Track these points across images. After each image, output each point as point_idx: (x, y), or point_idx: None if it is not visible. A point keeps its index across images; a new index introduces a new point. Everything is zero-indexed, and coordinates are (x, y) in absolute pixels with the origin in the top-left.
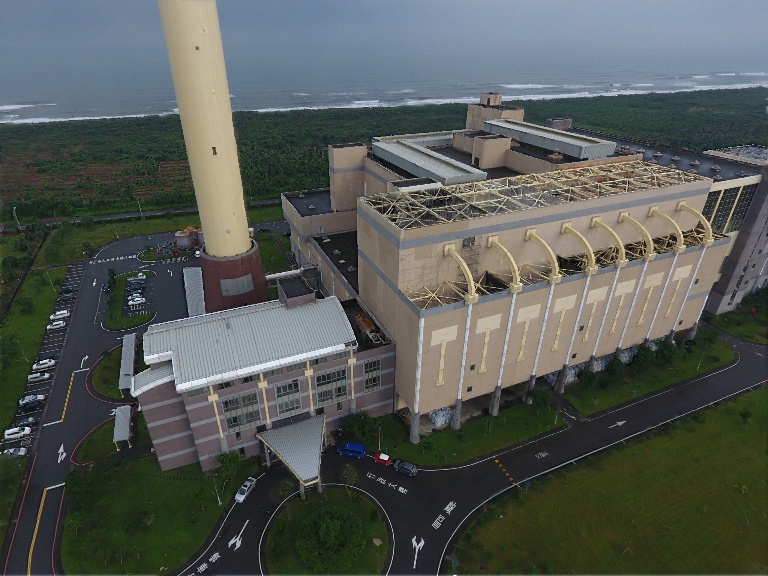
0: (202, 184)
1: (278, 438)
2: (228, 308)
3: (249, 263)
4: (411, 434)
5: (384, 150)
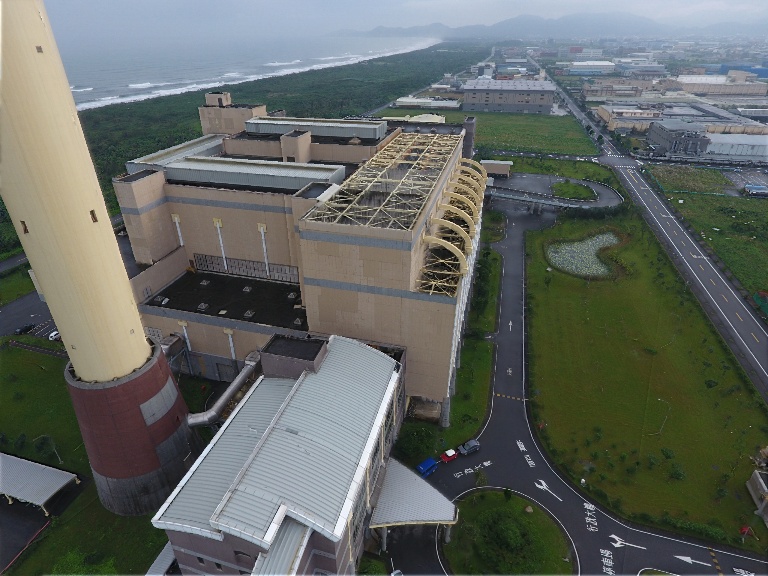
0: (80, 275)
1: (390, 510)
2: (159, 439)
3: (164, 362)
4: (444, 420)
5: (195, 170)
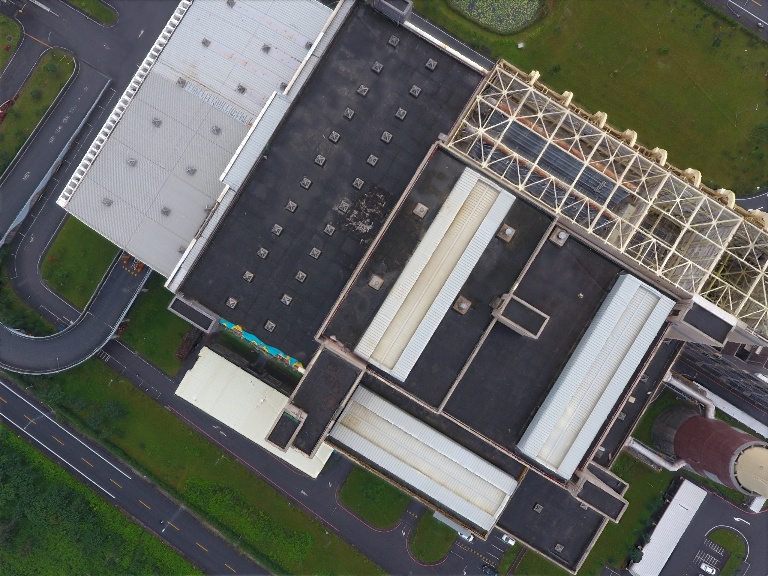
0: None
1: None
2: None
3: None
4: None
5: None
